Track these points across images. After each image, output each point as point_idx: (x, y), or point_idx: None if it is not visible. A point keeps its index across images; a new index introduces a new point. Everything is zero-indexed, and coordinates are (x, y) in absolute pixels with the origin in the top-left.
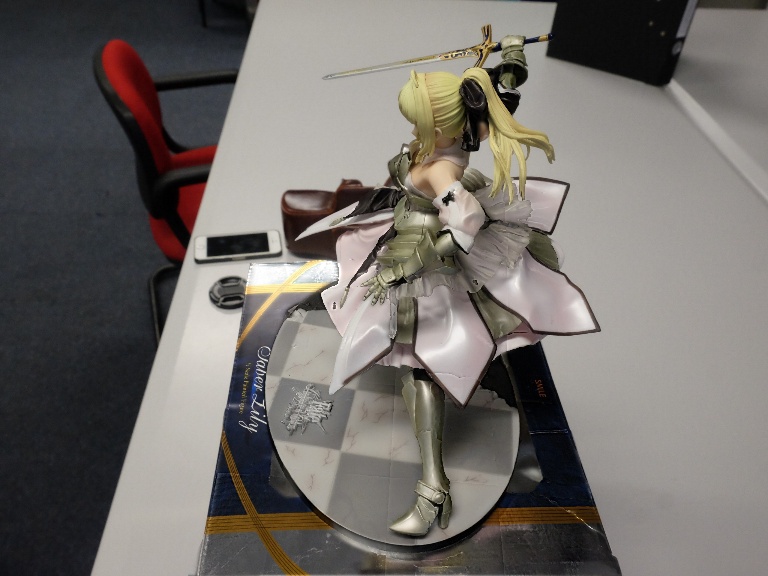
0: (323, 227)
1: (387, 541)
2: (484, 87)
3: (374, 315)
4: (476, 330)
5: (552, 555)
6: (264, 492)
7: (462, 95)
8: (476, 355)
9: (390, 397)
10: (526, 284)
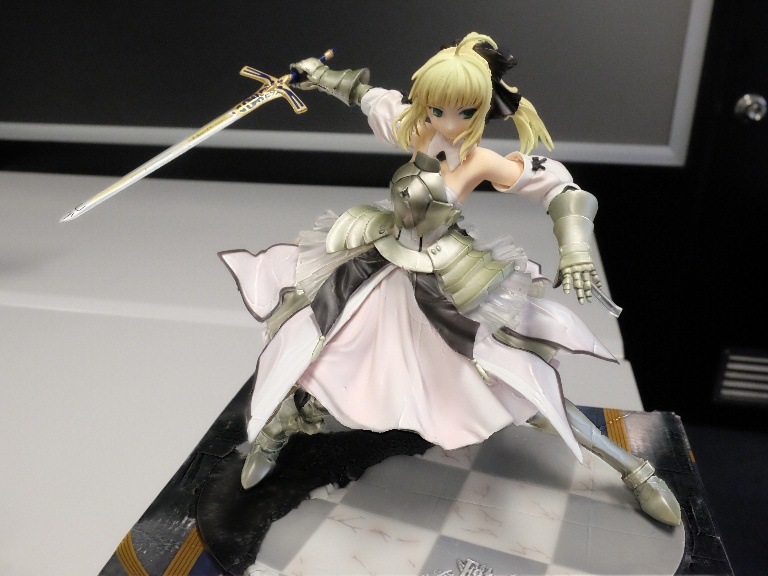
0: (288, 381)
1: (683, 541)
2: None
3: (514, 360)
4: None
5: (662, 442)
6: None
7: (500, 54)
8: None
9: (458, 504)
10: None
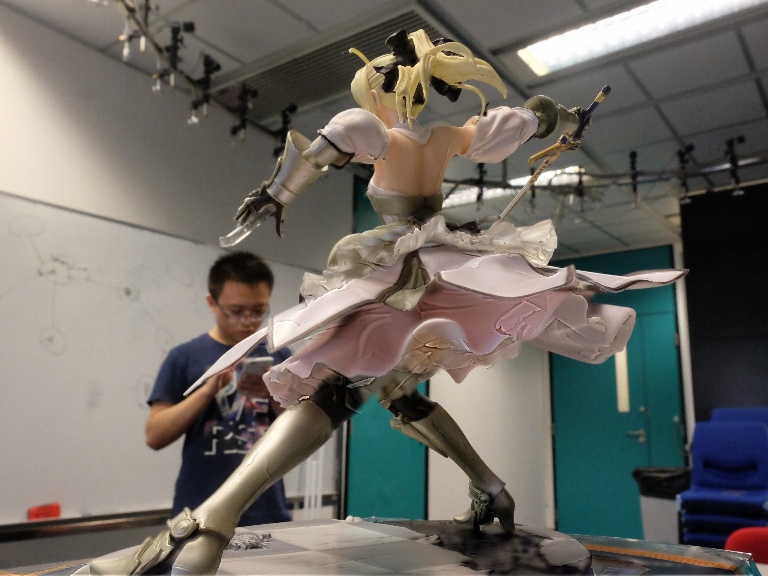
0: None
1: None
2: (415, 38)
3: None
4: (365, 290)
5: None
6: (71, 572)
7: None
8: (336, 300)
9: (344, 560)
10: (484, 266)
